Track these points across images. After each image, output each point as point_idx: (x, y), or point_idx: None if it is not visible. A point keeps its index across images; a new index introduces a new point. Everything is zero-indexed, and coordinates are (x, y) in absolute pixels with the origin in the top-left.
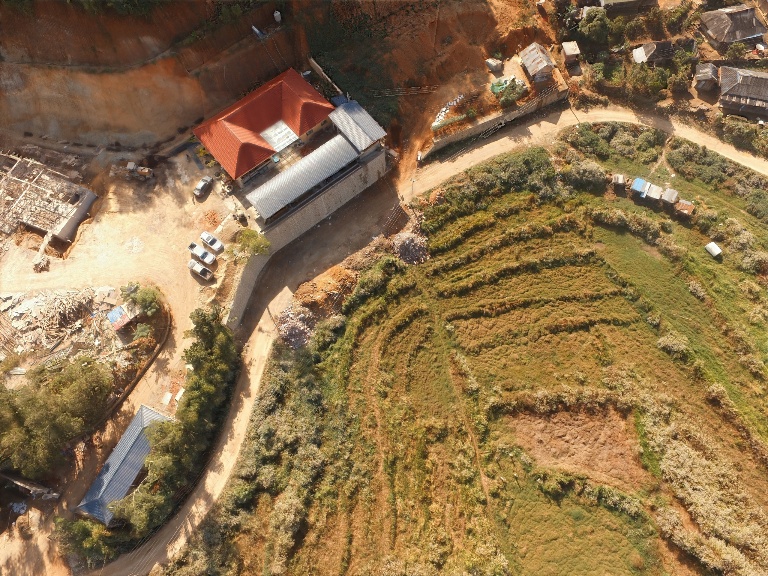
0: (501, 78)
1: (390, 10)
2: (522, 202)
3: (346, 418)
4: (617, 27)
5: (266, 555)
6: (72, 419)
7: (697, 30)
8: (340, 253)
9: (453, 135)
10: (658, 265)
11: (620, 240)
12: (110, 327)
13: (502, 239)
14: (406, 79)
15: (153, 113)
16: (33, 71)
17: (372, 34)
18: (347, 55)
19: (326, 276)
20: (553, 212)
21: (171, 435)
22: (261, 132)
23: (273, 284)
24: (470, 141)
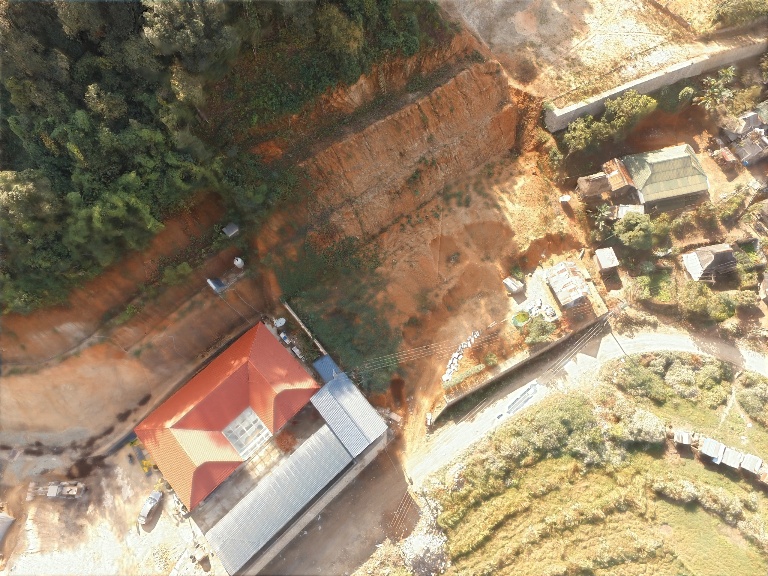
0: (524, 303)
1: (381, 225)
2: (563, 474)
3: None
4: (662, 229)
5: None
6: None
7: (758, 221)
8: (335, 574)
9: (470, 390)
10: (744, 559)
11: (691, 520)
12: None
13: (542, 531)
14: (406, 320)
15: (82, 406)
16: None
17: (360, 263)
18: (330, 293)
19: None
20: (603, 485)
21: None
22: (223, 428)
23: None
24: (491, 389)
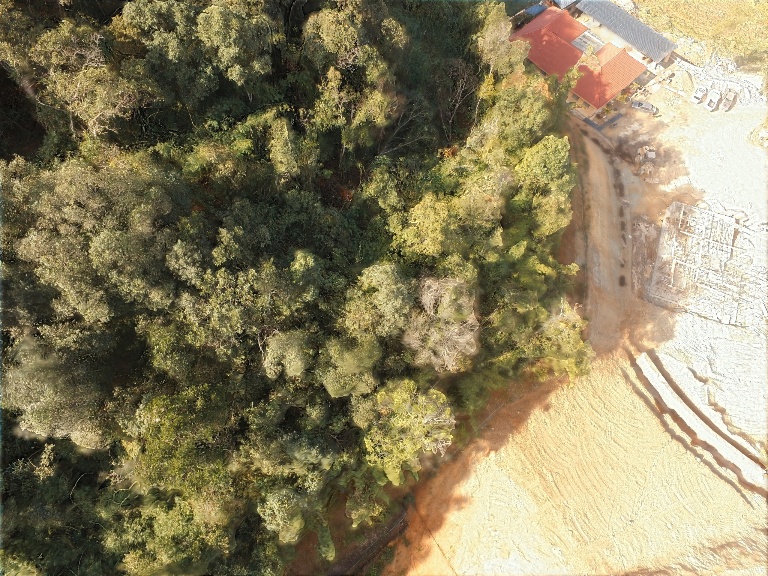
0: None
1: None
2: None
3: None
4: None
5: None
6: None
7: None
8: None
9: None
10: None
11: None
12: None
13: None
14: None
15: None
16: (591, 231)
17: None
18: None
19: None
20: None
21: None
22: None
23: None
24: None
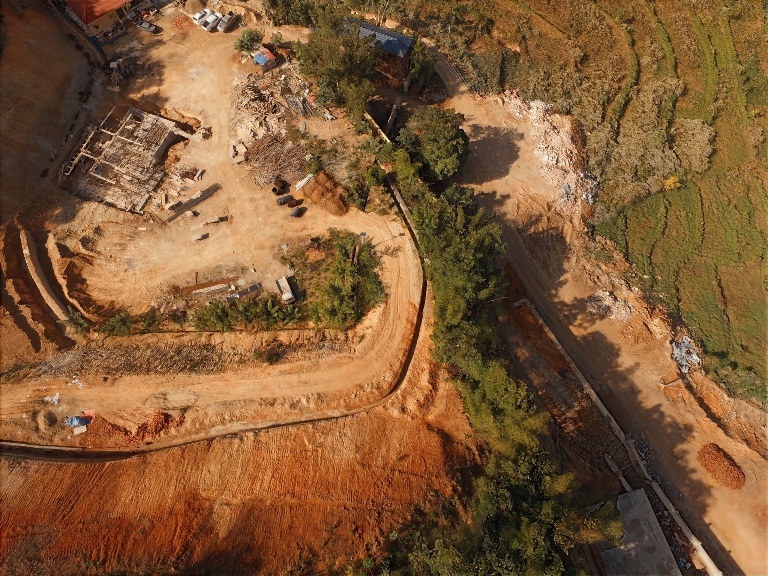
0: None
1: None
2: None
3: None
4: None
5: (431, 2)
6: None
7: None
8: None
9: None
10: None
11: None
12: None
13: None
14: None
15: (56, 51)
16: None
17: None
18: None
19: None
20: None
21: None
22: None
23: None
24: None
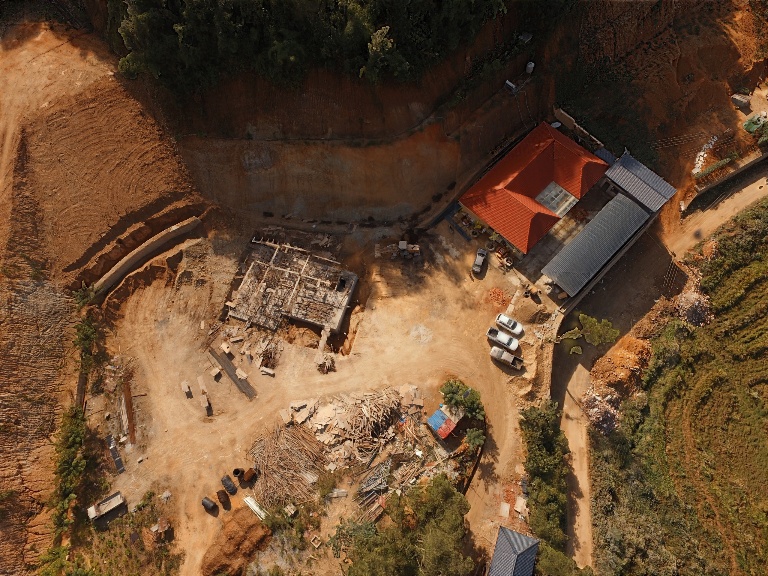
0: (751, 115)
1: (626, 50)
2: None
3: (681, 510)
4: None
5: None
6: (465, 560)
7: None
8: (625, 321)
9: (716, 181)
10: None
11: None
12: (428, 433)
13: None
14: (659, 124)
15: (412, 183)
16: (286, 148)
17: (617, 78)
18: (594, 102)
19: (619, 349)
20: None
21: (590, 572)
22: (536, 197)
23: (565, 362)
24: (728, 185)
